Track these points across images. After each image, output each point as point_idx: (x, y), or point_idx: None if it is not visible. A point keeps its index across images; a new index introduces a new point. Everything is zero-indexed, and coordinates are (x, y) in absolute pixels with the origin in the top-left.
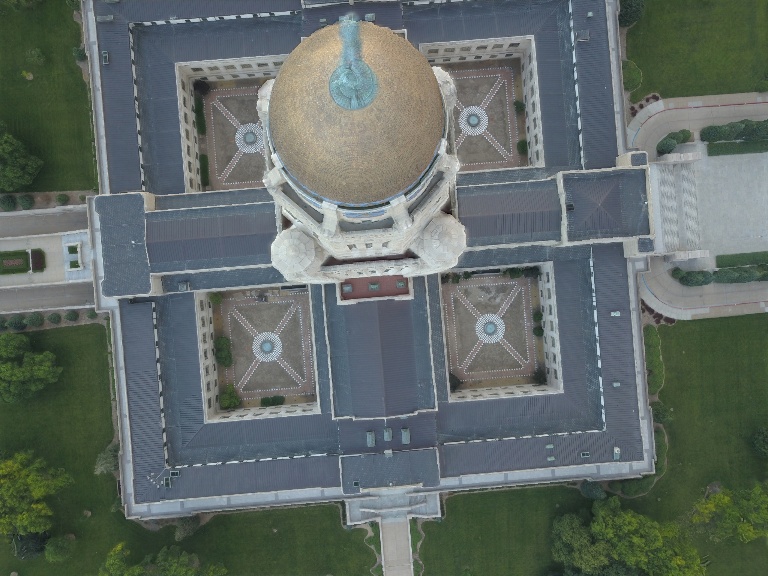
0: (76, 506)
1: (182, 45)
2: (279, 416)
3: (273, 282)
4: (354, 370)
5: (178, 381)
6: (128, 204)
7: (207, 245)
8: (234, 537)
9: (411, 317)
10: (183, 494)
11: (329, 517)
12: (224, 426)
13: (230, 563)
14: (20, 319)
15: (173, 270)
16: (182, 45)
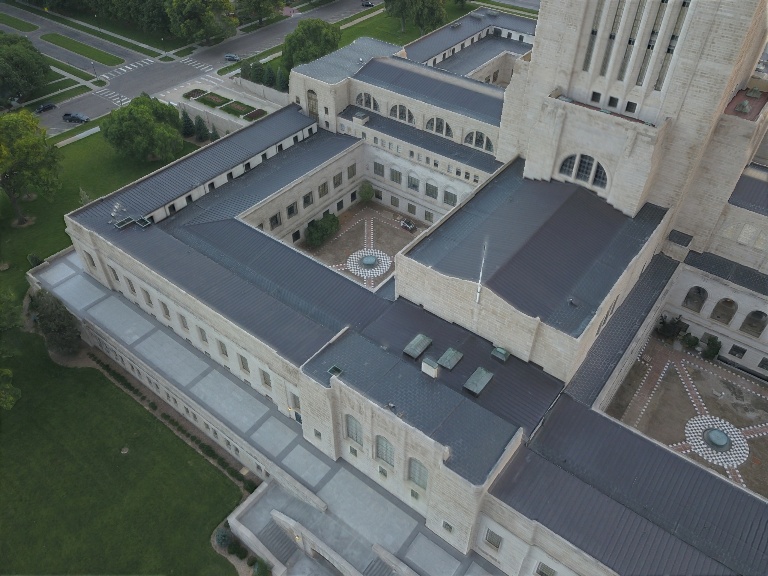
0: (8, 255)
1: (521, 50)
2: (320, 263)
3: (453, 159)
4: (481, 231)
5: (258, 181)
6: (385, 48)
7: (424, 82)
8: (73, 411)
9: (616, 233)
10: (120, 243)
11: (212, 500)
12: (249, 233)
13: (20, 440)
14: (194, 126)
15: (372, 84)
16: (521, 50)
